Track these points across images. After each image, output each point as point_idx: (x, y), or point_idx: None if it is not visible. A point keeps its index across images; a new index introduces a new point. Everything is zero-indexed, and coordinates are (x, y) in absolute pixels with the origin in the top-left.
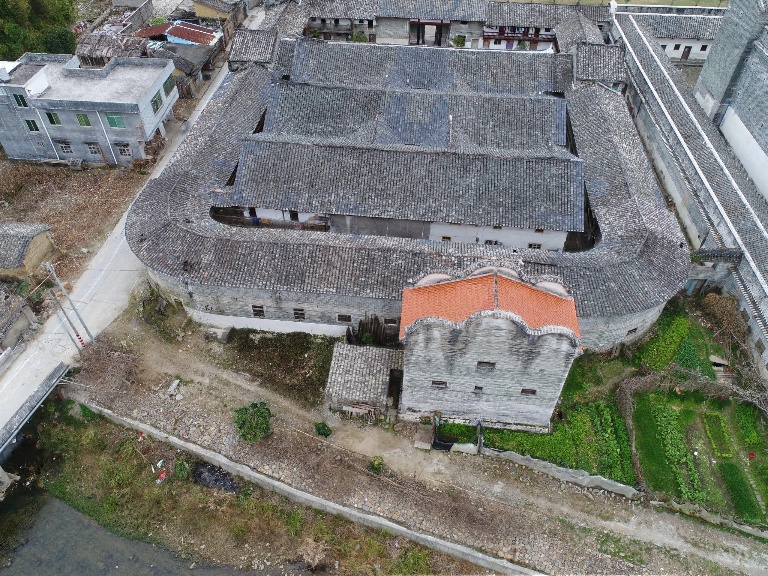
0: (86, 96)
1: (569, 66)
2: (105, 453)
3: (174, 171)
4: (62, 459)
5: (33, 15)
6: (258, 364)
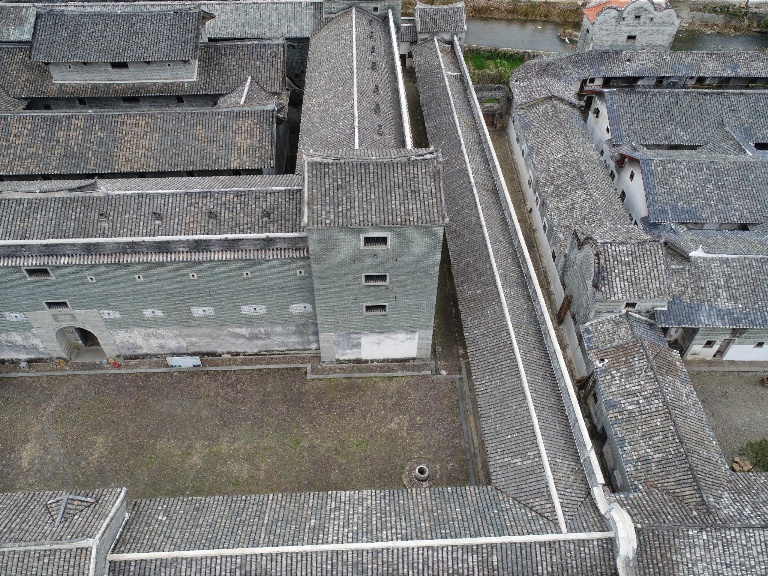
0: None
1: None
2: None
3: None
4: None
5: None
6: None
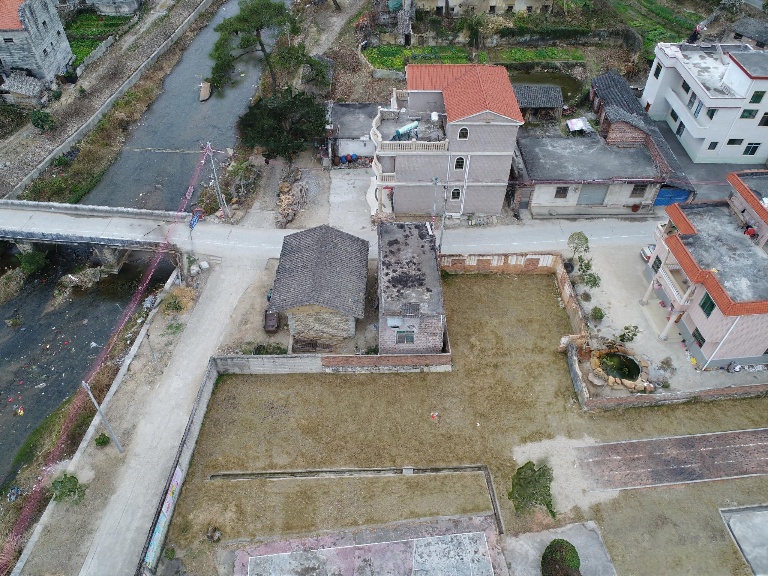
0: None
1: None
2: (38, 200)
3: None
4: None
5: None
6: None
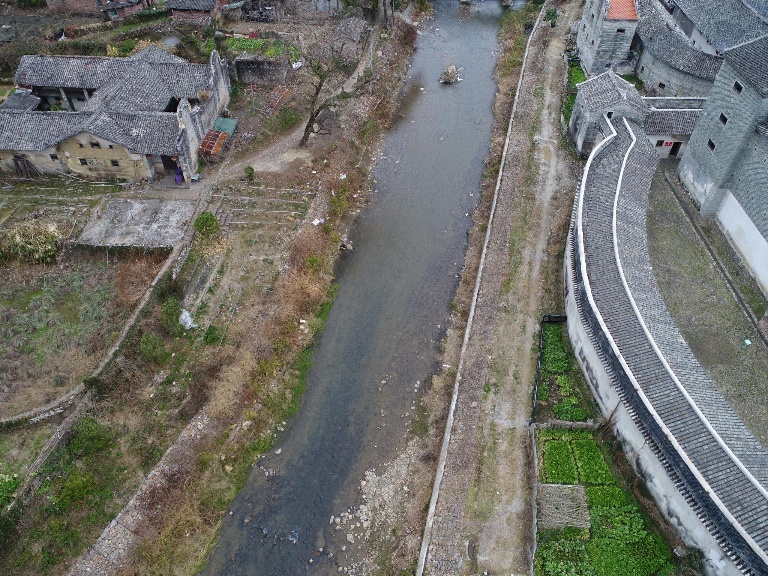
0: None
1: None
2: None
3: None
4: None
5: None
6: None
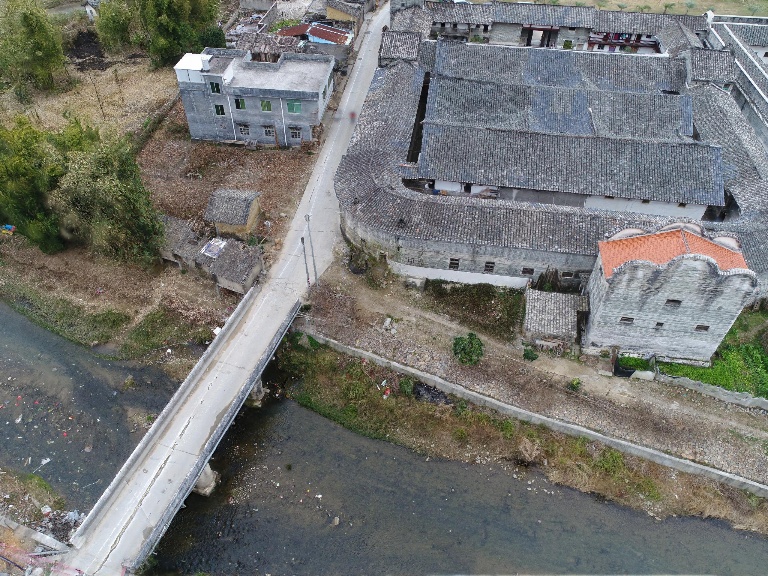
0: (268, 85)
1: (682, 68)
2: (335, 374)
3: (360, 149)
4: (300, 378)
5: (189, 15)
6: (453, 308)
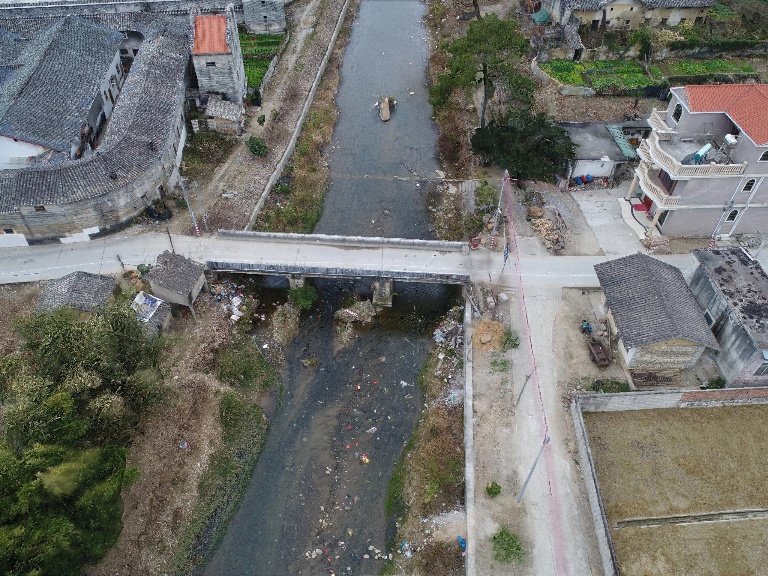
0: None
1: None
2: None
3: None
4: None
5: None
6: (207, 167)
